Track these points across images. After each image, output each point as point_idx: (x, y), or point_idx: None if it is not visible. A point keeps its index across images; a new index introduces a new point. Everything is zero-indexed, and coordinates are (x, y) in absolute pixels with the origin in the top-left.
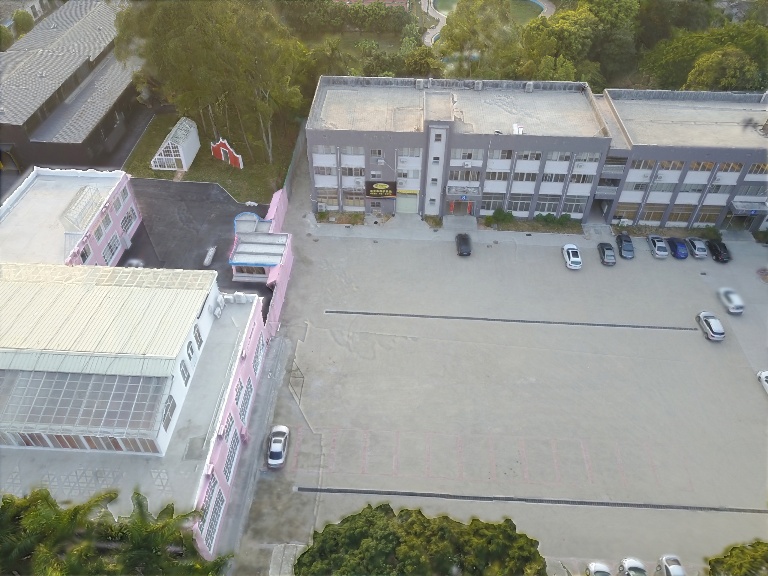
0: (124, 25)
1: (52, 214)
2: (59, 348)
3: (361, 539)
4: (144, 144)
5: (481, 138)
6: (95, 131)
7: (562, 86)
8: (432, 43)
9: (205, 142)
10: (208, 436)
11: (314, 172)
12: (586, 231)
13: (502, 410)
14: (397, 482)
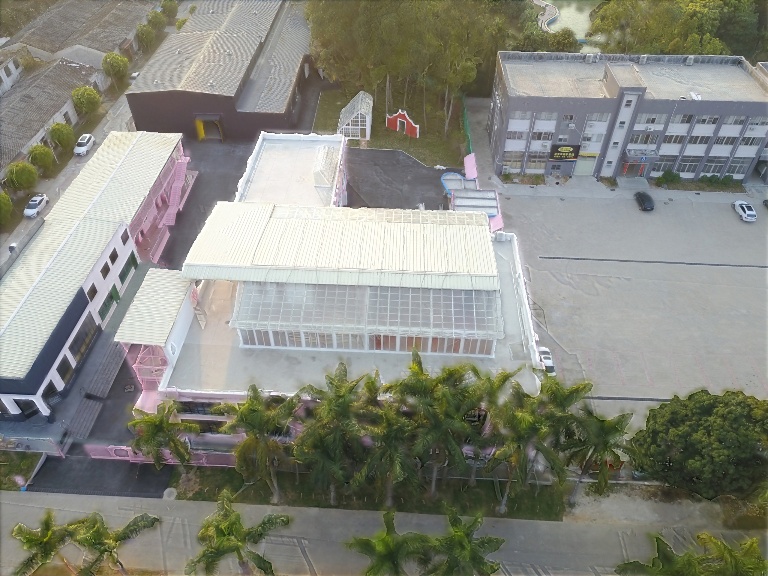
0: (324, 5)
1: (294, 171)
2: (394, 269)
3: (712, 409)
4: (321, 117)
5: (668, 103)
6: (289, 103)
7: (719, 60)
8: (546, 28)
9: (374, 115)
10: (524, 342)
11: (506, 137)
12: (749, 190)
13: (726, 335)
14: (656, 391)
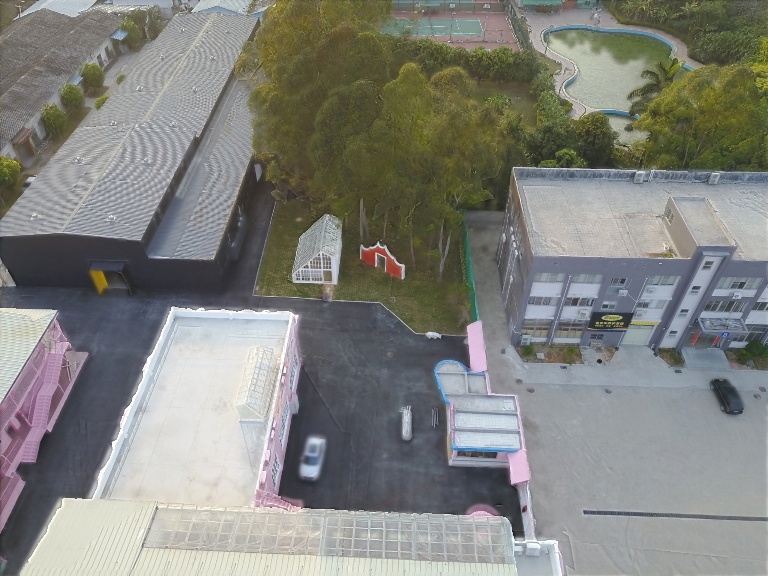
0: (269, 109)
1: (213, 386)
2: None
3: None
4: (273, 245)
5: (766, 266)
6: (224, 239)
7: None
8: (565, 94)
9: (345, 239)
10: None
11: (527, 302)
12: None
13: None
14: None
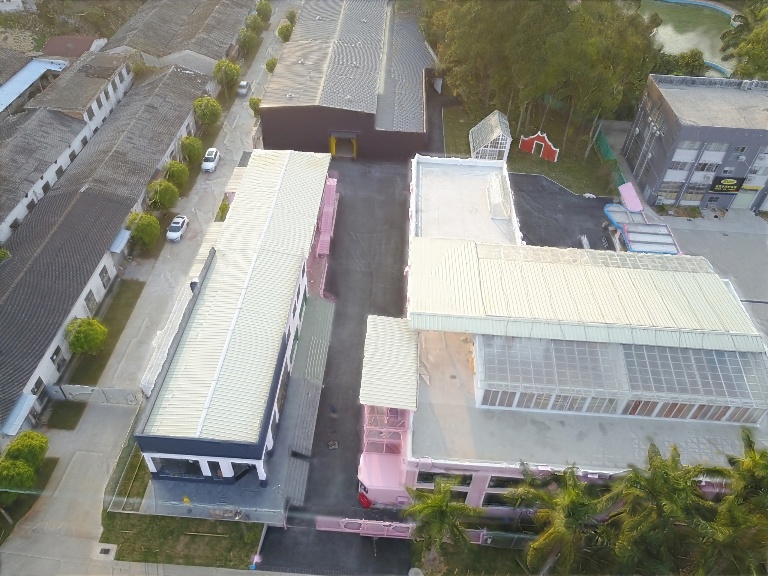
0: (473, 20)
1: (463, 200)
2: (643, 324)
3: None
4: (449, 135)
5: None
6: None
7: None
8: None
9: None
10: None
11: (668, 167)
12: None
13: None
14: None
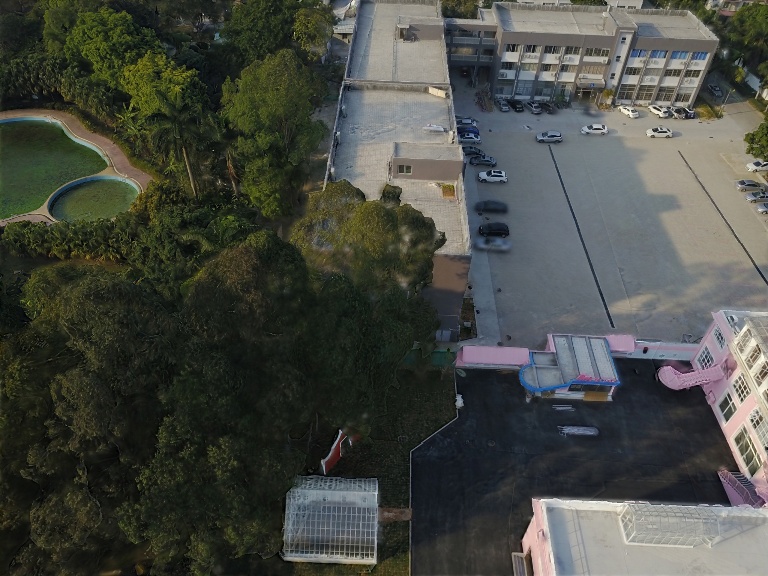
0: None
1: None
2: None
3: None
4: None
5: None
6: None
7: None
8: None
9: None
10: None
11: None
12: None
13: (670, 231)
14: (760, 284)
